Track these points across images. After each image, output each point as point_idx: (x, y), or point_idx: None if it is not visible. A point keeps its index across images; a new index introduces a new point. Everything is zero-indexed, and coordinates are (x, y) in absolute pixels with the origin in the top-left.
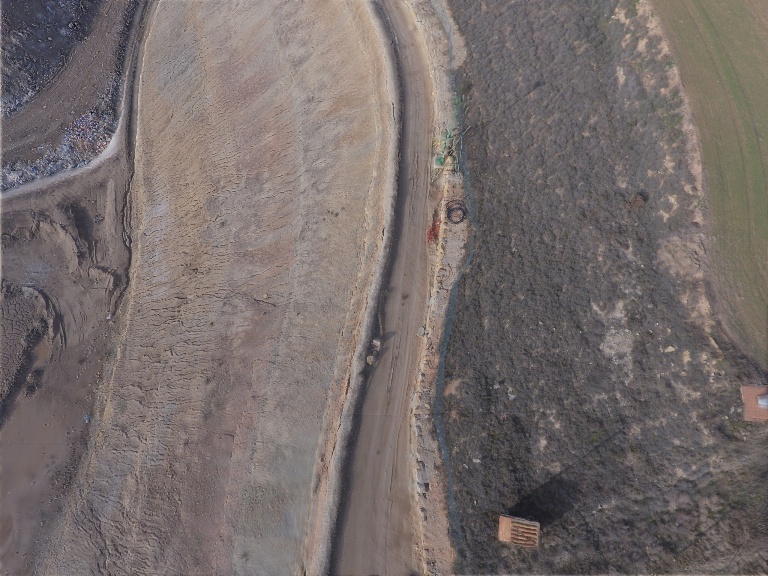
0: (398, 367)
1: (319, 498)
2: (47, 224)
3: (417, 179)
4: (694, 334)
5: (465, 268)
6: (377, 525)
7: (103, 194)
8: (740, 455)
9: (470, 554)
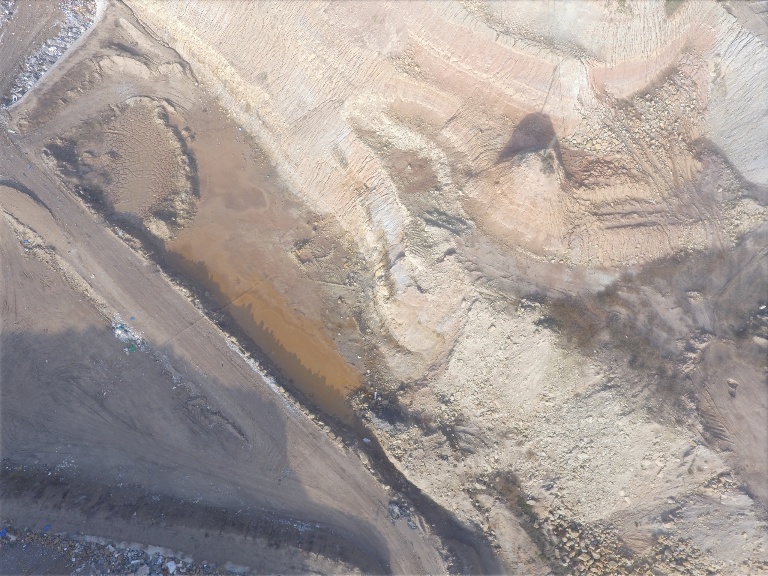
0: None
1: None
2: (106, 60)
3: None
4: None
5: None
6: None
7: (123, 31)
8: None
9: None
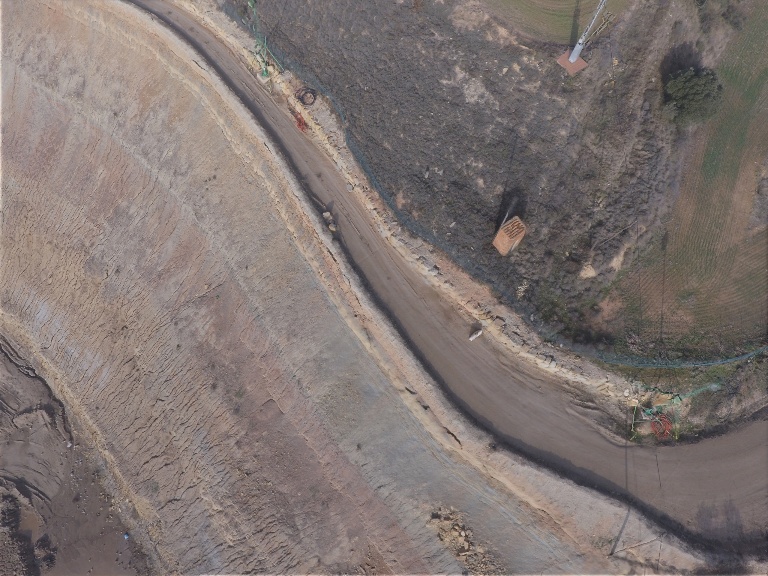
0: (354, 220)
1: (375, 336)
2: None
3: (258, 98)
4: (510, 51)
5: (344, 124)
6: (426, 318)
7: None
8: (585, 100)
9: (494, 278)
